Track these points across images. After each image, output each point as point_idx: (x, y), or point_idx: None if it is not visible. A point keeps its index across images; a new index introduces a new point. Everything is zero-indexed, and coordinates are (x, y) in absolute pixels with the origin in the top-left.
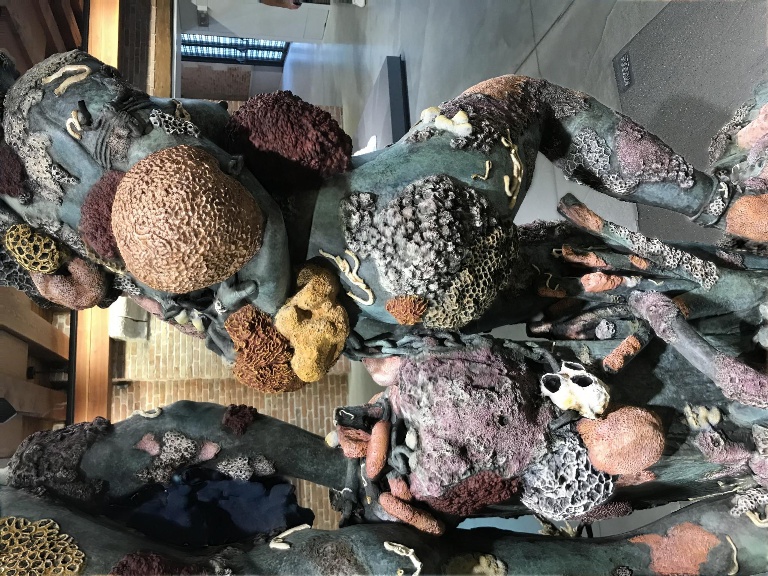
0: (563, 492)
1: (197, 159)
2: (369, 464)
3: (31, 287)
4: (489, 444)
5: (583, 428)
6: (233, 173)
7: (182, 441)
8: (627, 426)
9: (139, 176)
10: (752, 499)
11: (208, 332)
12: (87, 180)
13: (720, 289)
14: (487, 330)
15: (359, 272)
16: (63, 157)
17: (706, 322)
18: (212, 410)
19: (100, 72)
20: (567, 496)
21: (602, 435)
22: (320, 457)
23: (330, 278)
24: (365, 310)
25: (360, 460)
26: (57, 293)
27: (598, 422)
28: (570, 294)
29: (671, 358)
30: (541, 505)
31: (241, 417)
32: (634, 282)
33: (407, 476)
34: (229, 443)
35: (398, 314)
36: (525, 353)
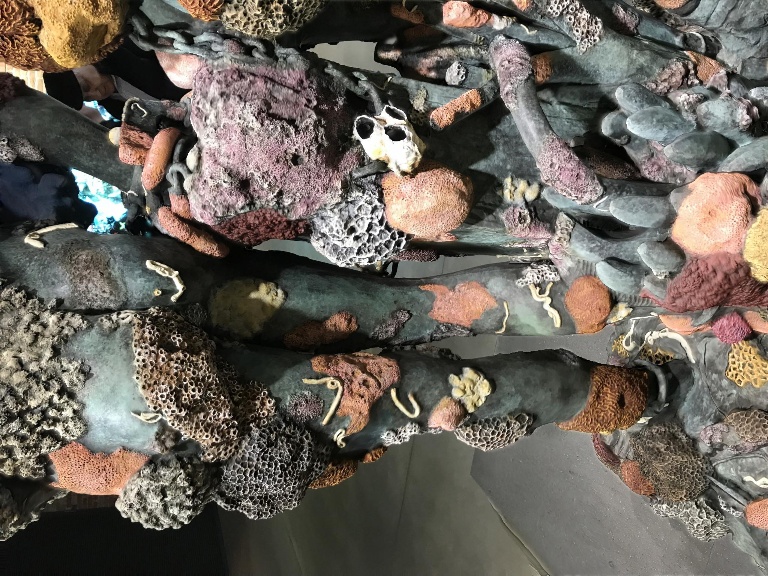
0: (350, 242)
1: None
2: (144, 176)
3: None
4: (276, 182)
5: (388, 182)
6: None
7: None
8: (432, 190)
9: None
10: (540, 274)
11: None
12: None
13: (595, 54)
14: (330, 41)
15: None
16: None
17: (567, 89)
18: None
19: None
20: (353, 247)
21: (404, 194)
22: (101, 153)
23: None
24: None
25: None
26: None
27: (405, 179)
28: (428, 21)
29: (513, 122)
30: (326, 250)
31: None
32: (503, 24)
33: None
34: None
35: (184, 3)
36: (348, 85)
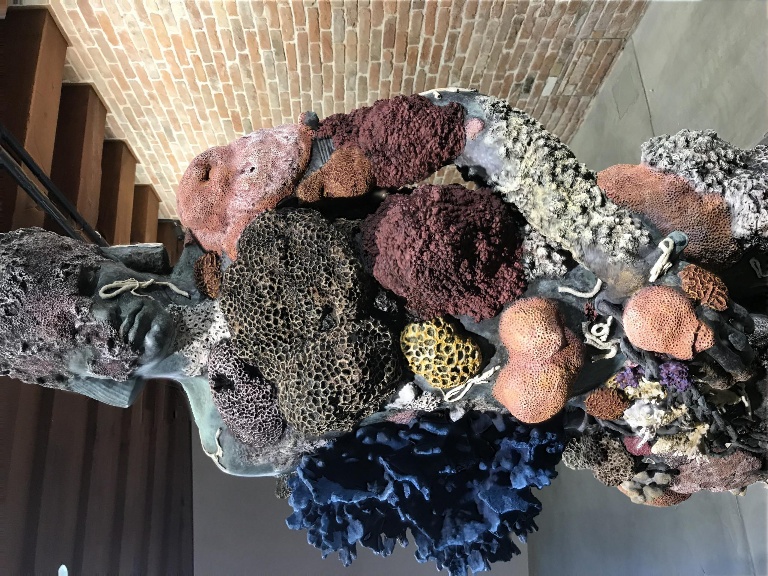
0: None
1: None
2: None
3: None
4: None
5: None
6: None
7: None
8: None
9: None
10: None
11: None
12: None
13: None
14: None
15: None
16: None
17: None
18: None
19: None
20: None
21: None
22: None
23: None
24: None
25: None
26: None
27: None
28: None
29: None
30: None
31: None
32: None
33: None
34: None
35: None
36: None
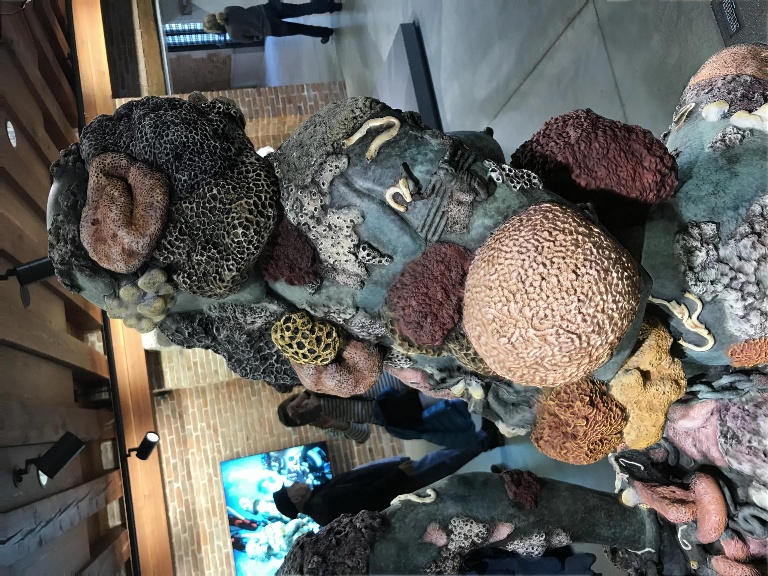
0: None
1: (583, 222)
2: (709, 530)
3: (288, 377)
4: None
5: None
6: (604, 230)
7: (472, 526)
8: None
9: (528, 256)
10: None
11: (487, 399)
12: (402, 257)
13: None
14: None
15: (700, 316)
16: (376, 234)
17: None
18: (489, 483)
19: (407, 122)
20: None
21: None
22: (615, 518)
23: (665, 328)
24: (692, 356)
25: (657, 515)
26: (333, 384)
27: None
28: None
29: None
30: None
31: (527, 488)
32: None
33: (743, 535)
34: (523, 520)
35: (747, 359)
36: None
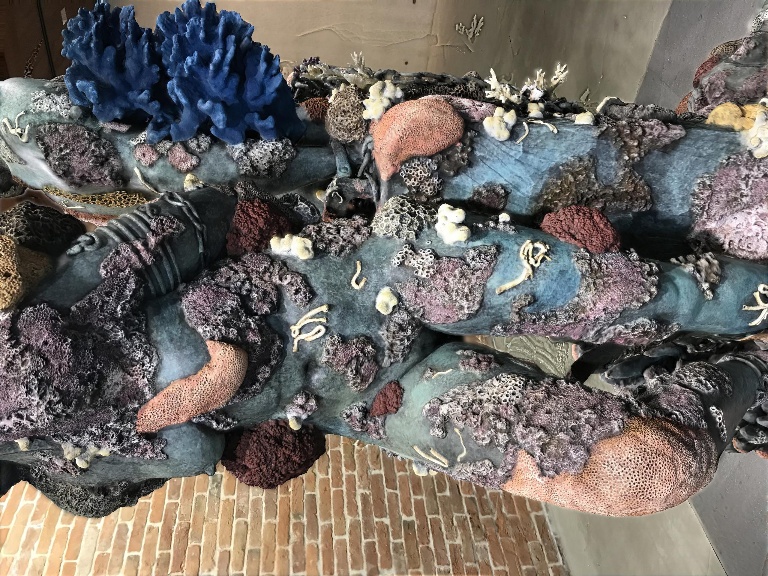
0: None
1: None
2: None
3: None
4: None
5: None
6: None
7: None
8: None
9: None
10: None
11: None
12: None
13: None
14: None
15: None
16: None
17: None
18: None
19: None
20: None
21: None
22: None
23: None
24: None
25: None
26: None
27: None
28: None
29: None
30: None
31: None
32: None
33: None
34: None
35: None
36: None
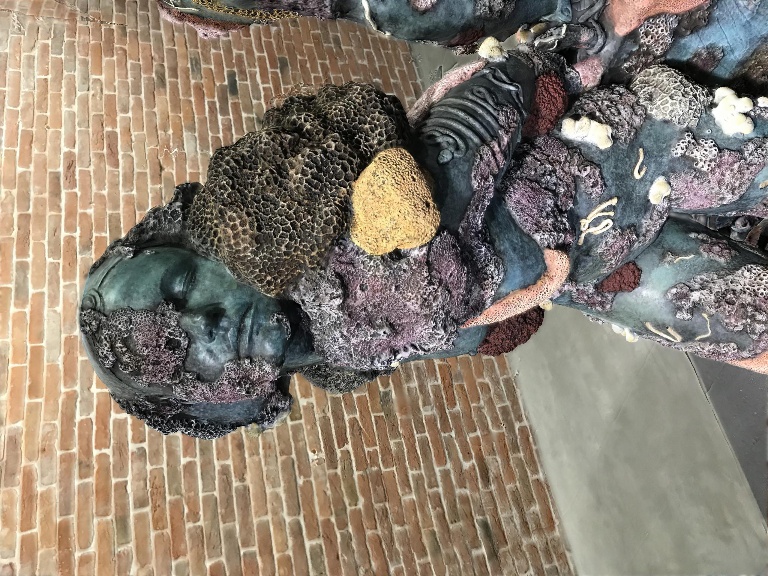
0: None
1: None
2: None
3: None
4: None
5: None
6: None
7: None
8: None
9: None
10: None
11: None
12: None
13: None
14: None
15: None
16: None
17: None
18: None
19: None
20: None
21: None
22: None
23: None
24: None
25: None
26: None
27: None
28: None
29: None
30: None
31: None
32: None
33: None
34: None
35: None
36: None
